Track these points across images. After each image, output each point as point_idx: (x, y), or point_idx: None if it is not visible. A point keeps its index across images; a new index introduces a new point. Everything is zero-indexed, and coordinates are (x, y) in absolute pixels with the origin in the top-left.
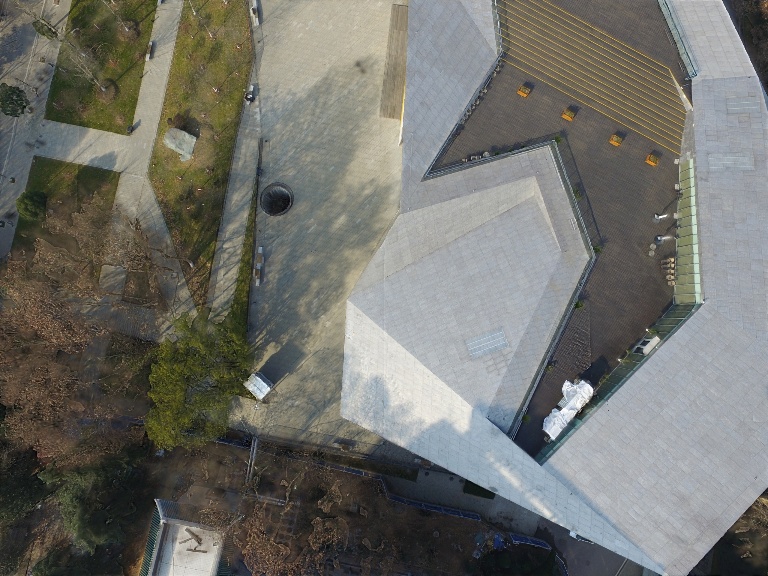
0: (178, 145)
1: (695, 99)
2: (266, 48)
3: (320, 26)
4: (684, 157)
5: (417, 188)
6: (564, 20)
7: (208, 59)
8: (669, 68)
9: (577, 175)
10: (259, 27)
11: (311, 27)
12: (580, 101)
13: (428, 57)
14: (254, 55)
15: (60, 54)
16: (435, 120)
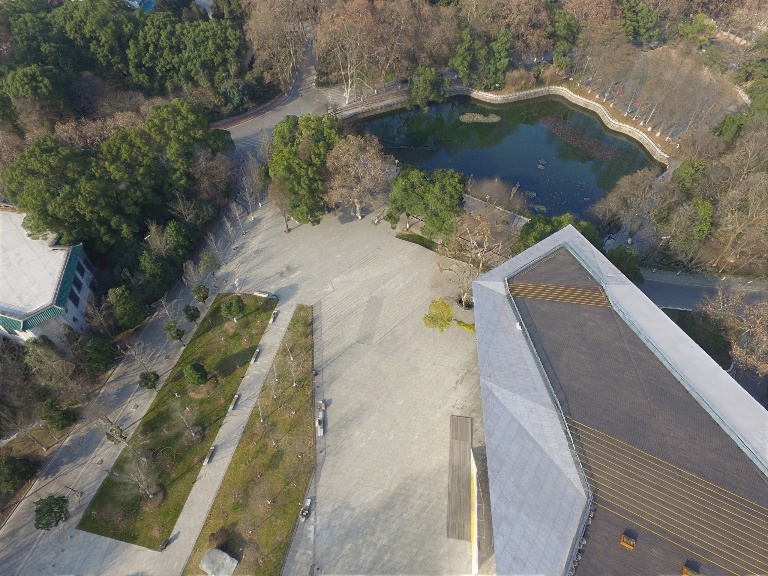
0: (215, 571)
1: None
2: (328, 458)
3: (382, 436)
4: None
5: None
6: (647, 461)
7: (267, 466)
8: None
9: None
10: (323, 437)
11: (373, 437)
12: (697, 554)
13: (513, 501)
14: (315, 465)
15: (120, 456)
16: None
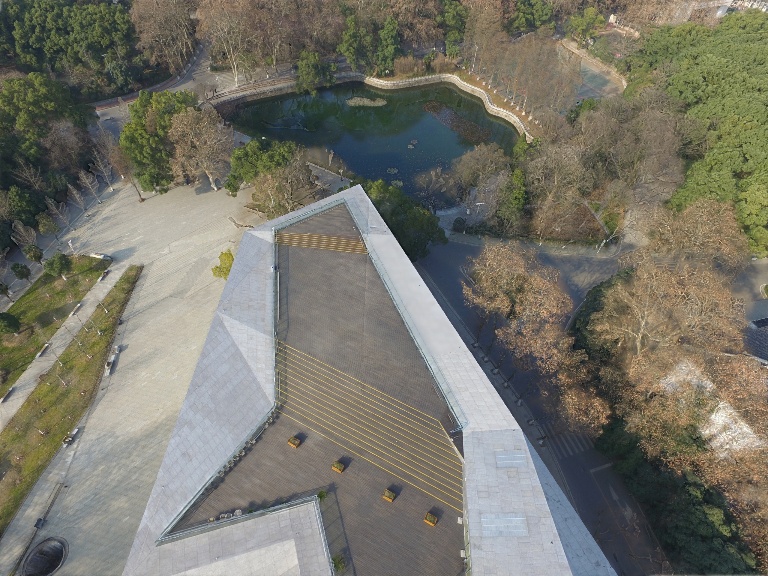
0: None
1: (466, 451)
2: (107, 394)
3: (166, 376)
4: (464, 516)
5: (149, 555)
6: (338, 378)
7: (52, 403)
8: (439, 420)
9: (344, 538)
10: (109, 377)
11: (157, 377)
12: (353, 452)
13: (203, 409)
14: (93, 401)
15: None
16: (194, 472)
